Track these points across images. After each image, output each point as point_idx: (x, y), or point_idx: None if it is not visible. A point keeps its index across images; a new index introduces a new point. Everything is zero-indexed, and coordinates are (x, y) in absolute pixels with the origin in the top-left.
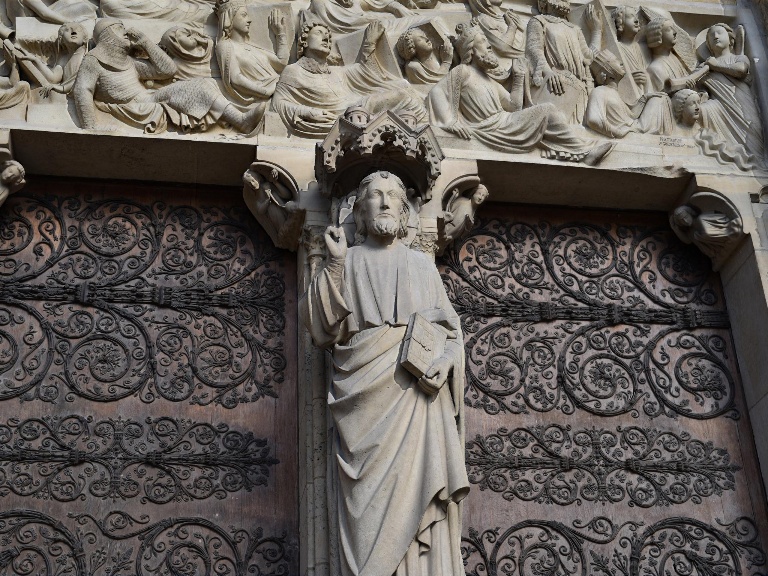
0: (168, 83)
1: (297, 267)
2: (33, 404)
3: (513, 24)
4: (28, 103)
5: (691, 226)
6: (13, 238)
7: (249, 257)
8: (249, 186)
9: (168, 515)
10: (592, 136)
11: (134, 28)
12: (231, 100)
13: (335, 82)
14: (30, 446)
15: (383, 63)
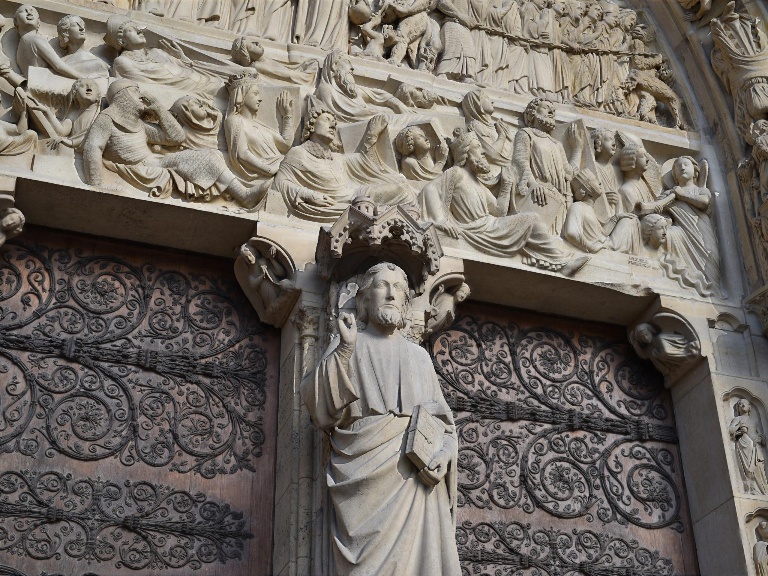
0: (175, 150)
1: (281, 344)
2: (12, 456)
3: (504, 133)
4: (35, 153)
5: (650, 343)
6: (1, 285)
7: (234, 329)
8: (245, 260)
9: None
10: (569, 248)
11: (147, 92)
12: (235, 174)
13: (337, 169)
14: (7, 499)
15: (382, 156)
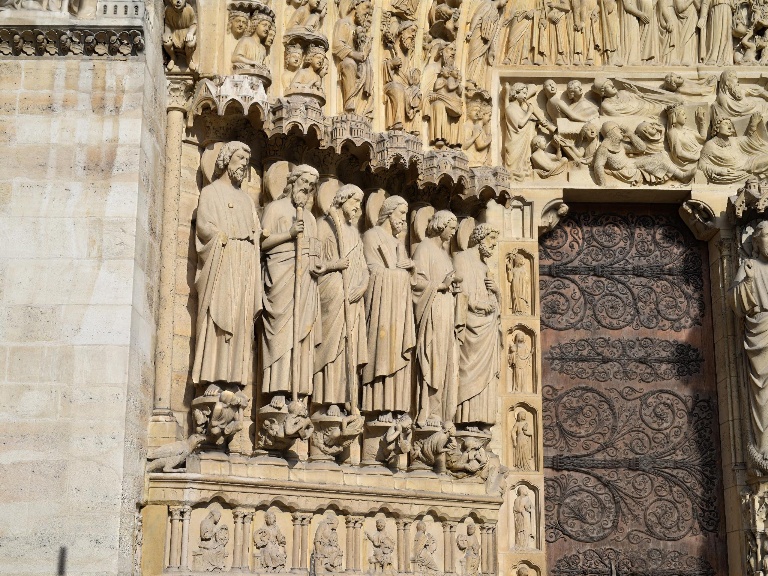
0: (641, 154)
1: (709, 251)
2: (581, 331)
3: None
4: (568, 170)
5: None
6: (558, 239)
7: (682, 245)
8: None
9: (652, 388)
10: None
11: (623, 125)
12: (676, 164)
13: (734, 151)
14: (582, 354)
15: (760, 135)
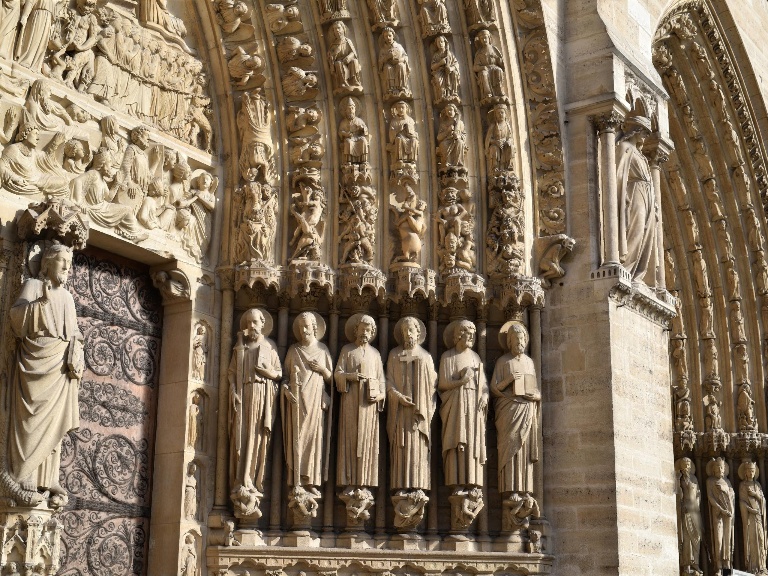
0: None
1: None
2: None
3: None
4: None
5: (163, 282)
6: None
7: None
8: None
9: None
10: (139, 225)
11: None
12: None
13: None
14: None
15: (57, 156)
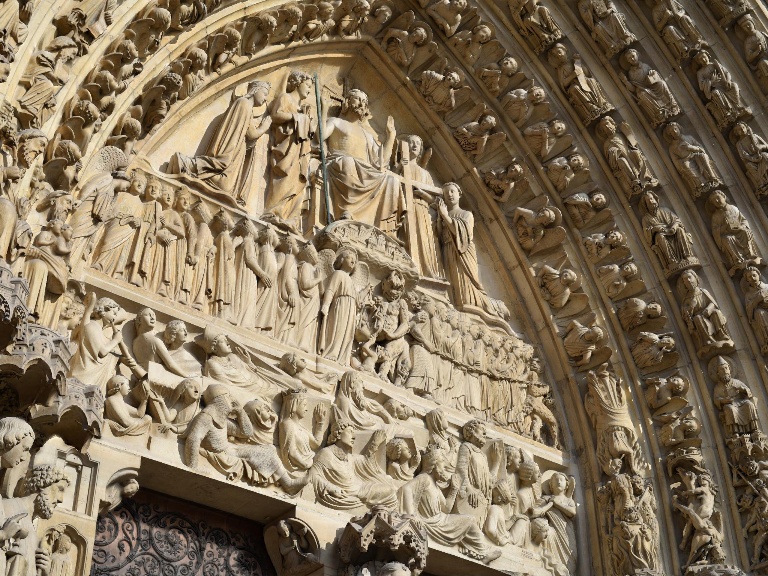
0: (243, 441)
1: None
2: None
3: None
4: (150, 434)
5: None
6: (104, 532)
7: None
8: (282, 533)
9: None
10: (487, 541)
11: (232, 395)
12: (284, 466)
13: (351, 469)
14: None
15: (378, 459)
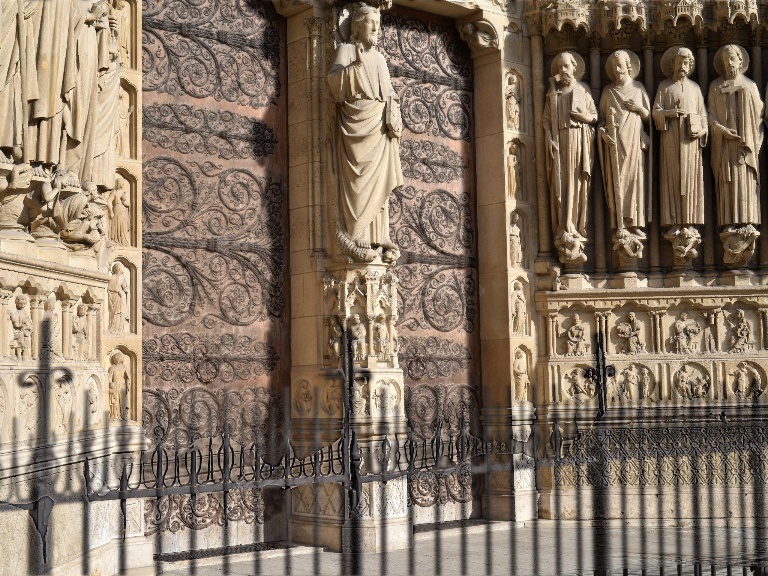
0: None
1: (287, 27)
2: (164, 95)
3: None
4: None
5: (470, 35)
6: None
7: (263, 16)
8: None
9: (231, 166)
10: None
11: None
12: None
13: None
14: (165, 120)
15: None
